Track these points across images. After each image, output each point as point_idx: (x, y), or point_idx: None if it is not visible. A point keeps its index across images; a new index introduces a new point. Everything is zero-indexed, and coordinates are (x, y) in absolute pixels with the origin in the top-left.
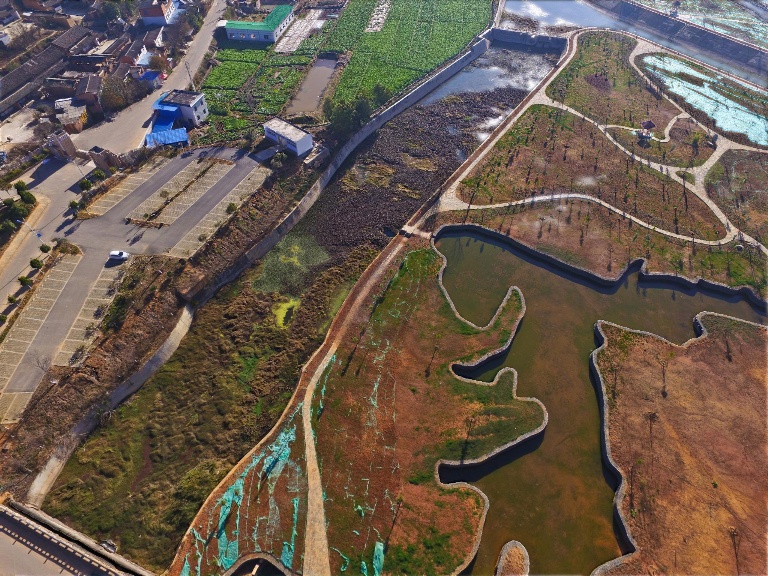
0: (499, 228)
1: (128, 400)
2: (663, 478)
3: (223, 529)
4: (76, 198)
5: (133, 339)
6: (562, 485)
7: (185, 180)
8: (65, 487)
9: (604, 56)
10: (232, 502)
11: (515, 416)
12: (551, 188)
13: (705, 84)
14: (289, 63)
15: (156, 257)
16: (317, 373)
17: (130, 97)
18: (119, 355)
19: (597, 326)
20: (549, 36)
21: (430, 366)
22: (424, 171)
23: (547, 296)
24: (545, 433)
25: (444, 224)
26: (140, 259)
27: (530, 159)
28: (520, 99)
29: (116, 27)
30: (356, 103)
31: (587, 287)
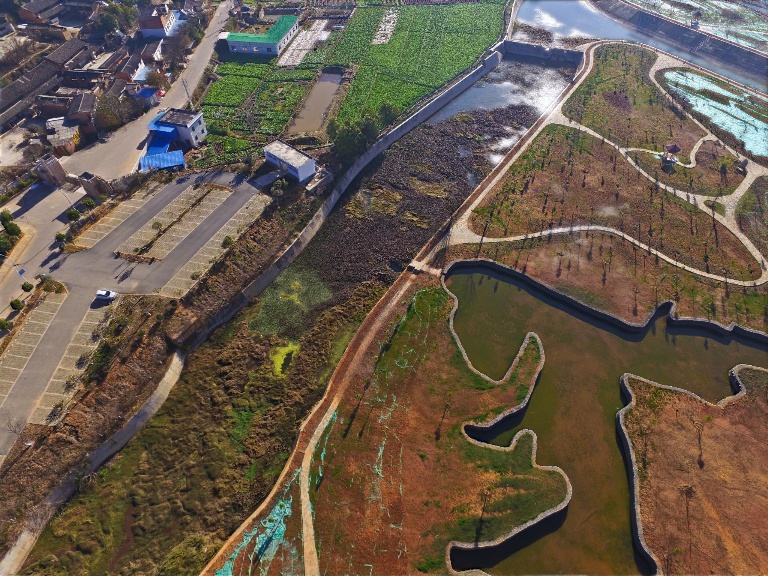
0: (514, 264)
1: (111, 461)
2: (703, 568)
3: None
4: (64, 229)
5: (117, 392)
6: (589, 573)
7: (180, 209)
8: (37, 565)
9: (623, 71)
10: None
11: (535, 489)
12: (570, 219)
13: (731, 102)
14: (292, 78)
15: (146, 297)
16: (316, 433)
17: (125, 116)
18: (102, 410)
19: (623, 381)
20: (564, 49)
21: (440, 427)
22: (433, 197)
23: (567, 343)
24: (568, 508)
25: (455, 259)
26: (128, 299)
27: (547, 186)
28: (534, 117)
29: (114, 39)
30: (362, 124)
31: (611, 333)
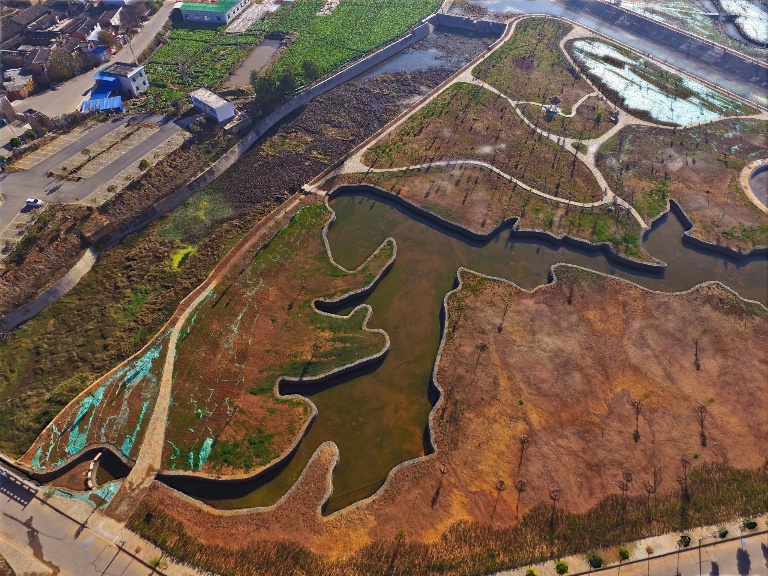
0: (391, 188)
1: (24, 324)
2: (477, 396)
3: (77, 424)
4: (7, 154)
5: (34, 272)
6: (388, 401)
7: (110, 141)
8: None
9: (537, 40)
10: (91, 404)
11: (359, 343)
12: (450, 155)
13: (626, 66)
14: (236, 42)
15: (68, 205)
16: (192, 305)
17: (77, 69)
18: (19, 285)
19: (457, 272)
20: (490, 21)
21: (294, 301)
22: (340, 140)
23: (421, 247)
24: (385, 359)
25: (341, 184)
26: None
27: (438, 130)
28: None
29: (77, 7)
30: (282, 76)
31: (460, 241)
